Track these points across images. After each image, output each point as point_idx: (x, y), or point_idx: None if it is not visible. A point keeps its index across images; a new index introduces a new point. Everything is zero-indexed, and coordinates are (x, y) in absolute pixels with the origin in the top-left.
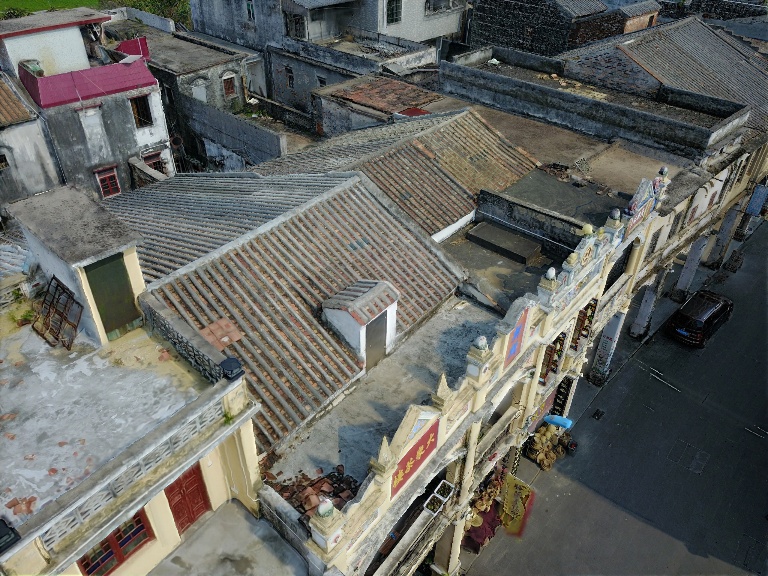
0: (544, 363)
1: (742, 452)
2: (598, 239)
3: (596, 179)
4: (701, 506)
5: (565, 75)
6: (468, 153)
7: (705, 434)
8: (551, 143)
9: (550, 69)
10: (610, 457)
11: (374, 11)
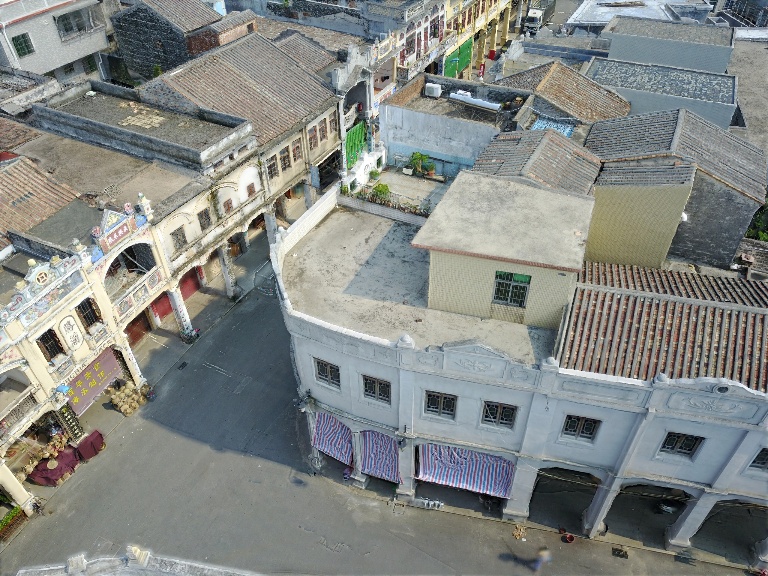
0: (44, 353)
1: (275, 371)
2: (53, 264)
3: (119, 201)
4: (231, 416)
5: (143, 101)
6: (11, 198)
7: (255, 364)
8: (105, 171)
9: (131, 97)
10: (180, 396)
11: (1, 49)
